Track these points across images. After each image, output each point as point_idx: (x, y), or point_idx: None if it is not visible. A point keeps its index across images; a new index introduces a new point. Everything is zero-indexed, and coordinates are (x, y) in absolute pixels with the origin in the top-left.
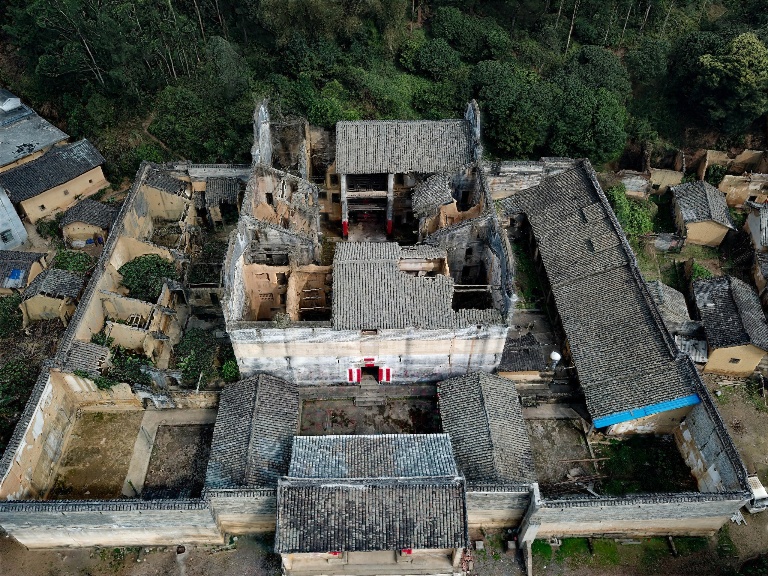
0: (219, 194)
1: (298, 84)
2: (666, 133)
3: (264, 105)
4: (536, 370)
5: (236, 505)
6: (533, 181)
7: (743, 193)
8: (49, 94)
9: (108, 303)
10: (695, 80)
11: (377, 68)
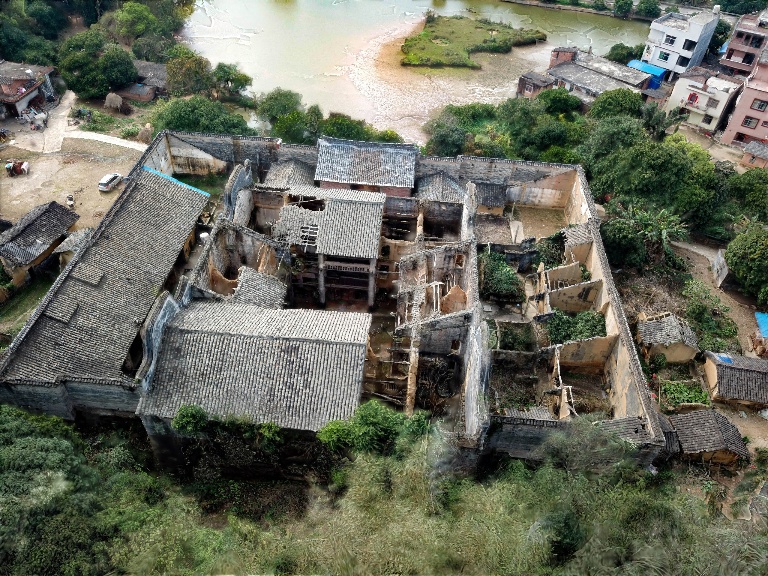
0: (533, 415)
1: None
2: None
3: (484, 408)
4: None
5: None
6: None
7: None
8: None
9: None
10: None
11: None
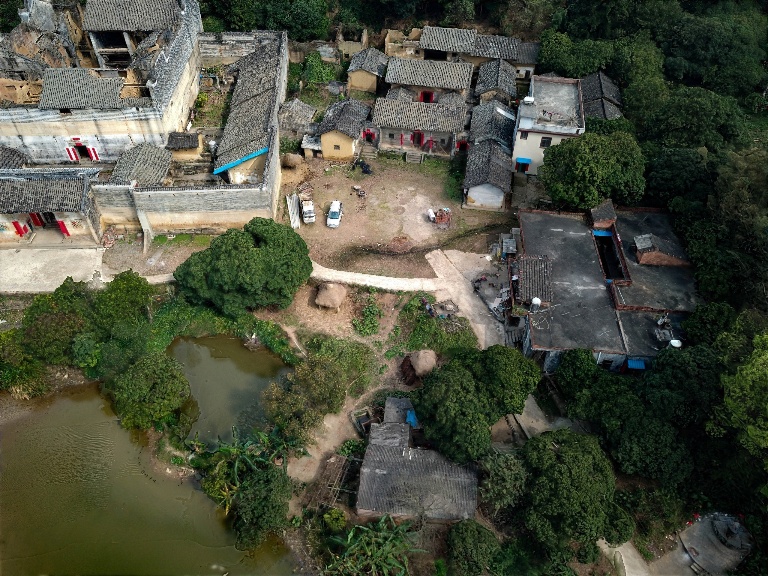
0: None
1: None
2: (368, 21)
3: None
4: (191, 147)
5: None
6: (250, 48)
7: (405, 57)
8: None
9: None
10: None
11: None
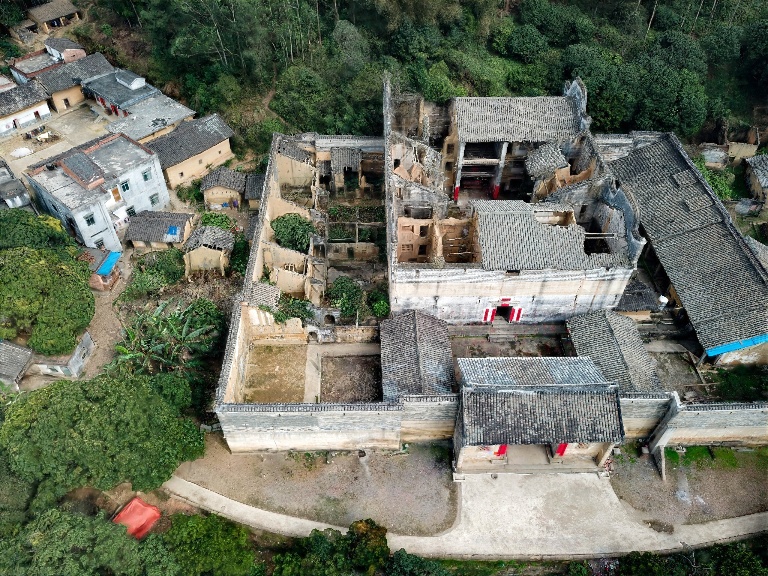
0: (343, 162)
1: (415, 64)
2: (736, 111)
3: None
4: (650, 310)
5: (419, 411)
6: (623, 152)
7: None
8: (172, 74)
9: (267, 253)
10: (765, 63)
11: (473, 52)
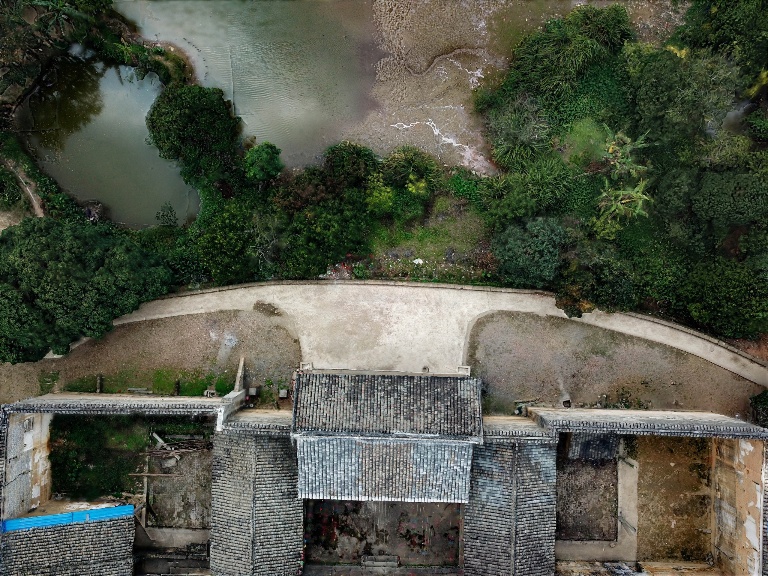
0: None
1: None
2: None
3: None
4: None
5: (522, 429)
6: None
7: None
8: None
9: None
10: None
11: None
